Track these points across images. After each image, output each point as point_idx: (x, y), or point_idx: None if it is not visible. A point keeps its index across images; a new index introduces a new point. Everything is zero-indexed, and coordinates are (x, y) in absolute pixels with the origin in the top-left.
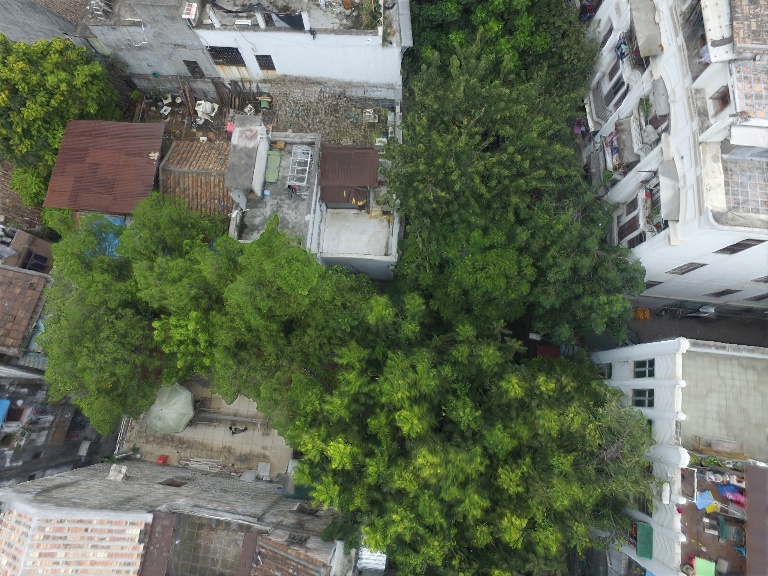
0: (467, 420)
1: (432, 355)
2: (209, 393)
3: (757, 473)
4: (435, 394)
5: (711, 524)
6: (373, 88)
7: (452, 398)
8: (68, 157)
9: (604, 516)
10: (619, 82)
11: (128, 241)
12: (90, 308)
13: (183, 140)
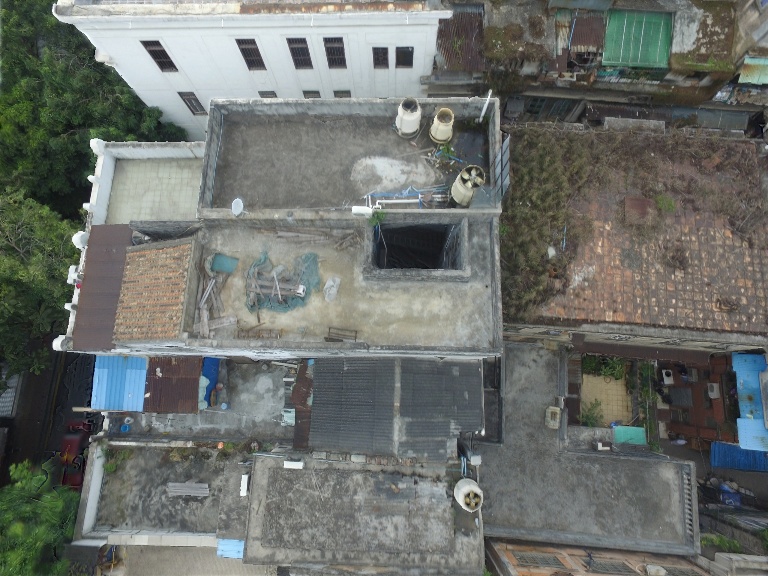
0: None
1: None
2: None
3: (98, 231)
4: None
5: None
6: None
7: None
8: None
9: None
10: None
11: None
12: None
13: None
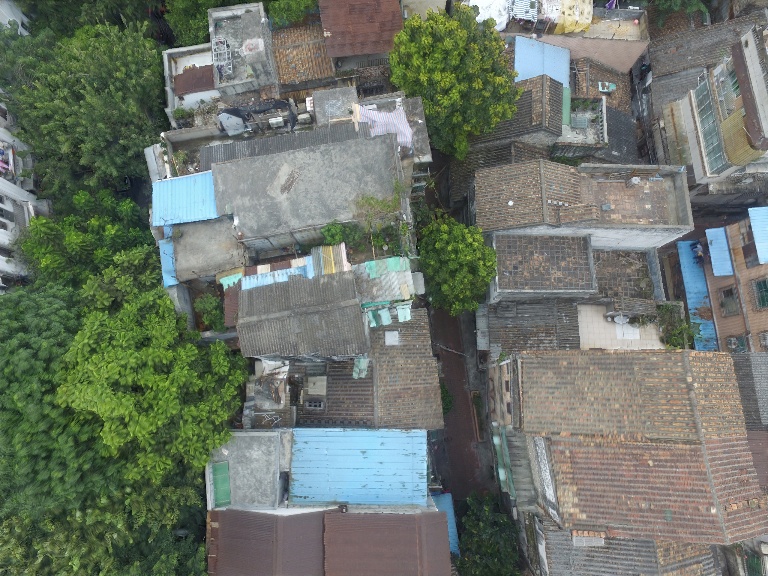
0: None
1: None
2: None
3: None
4: None
5: None
6: None
7: None
8: (394, 24)
9: None
10: None
11: None
12: None
13: None
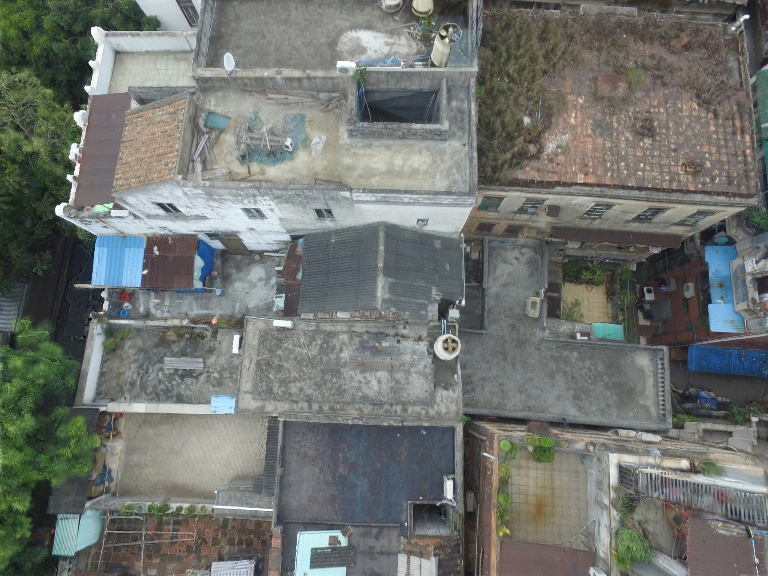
0: None
1: None
2: None
3: (99, 100)
4: None
5: None
6: None
7: None
8: None
9: None
10: None
11: None
12: None
13: None
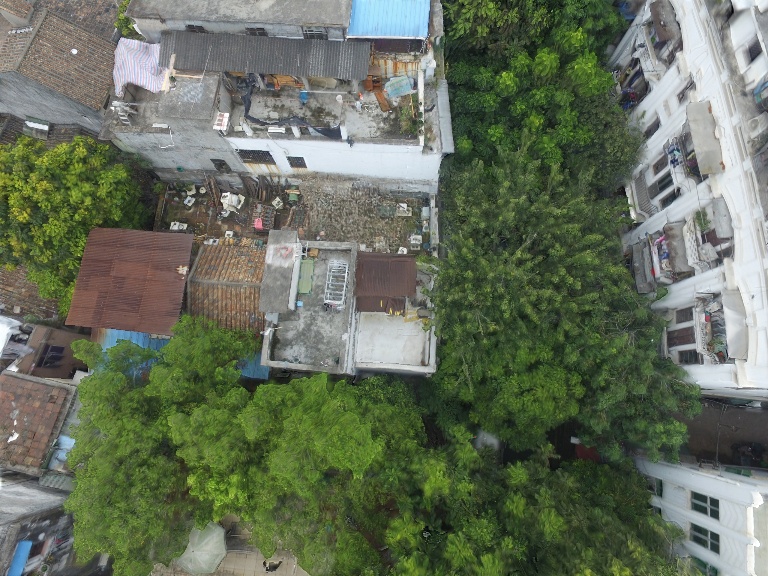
0: None
1: (491, 523)
2: (239, 517)
3: None
4: None
5: None
6: (408, 184)
7: (512, 569)
8: (91, 269)
9: None
10: (666, 179)
11: (160, 382)
12: None
13: (208, 233)
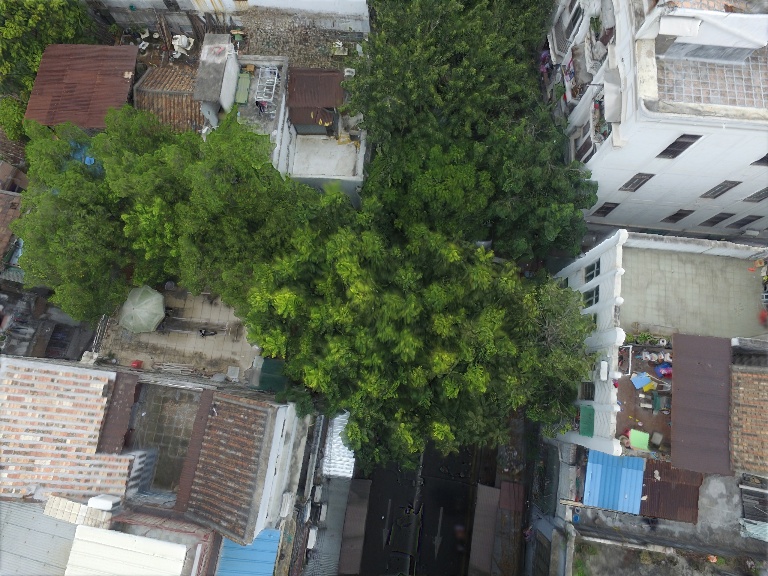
0: (408, 283)
1: None
2: (182, 304)
3: (683, 340)
4: (382, 266)
5: (646, 399)
6: (341, 19)
7: None
8: (46, 78)
9: (552, 405)
10: (577, 12)
11: (99, 142)
12: (63, 205)
13: None
